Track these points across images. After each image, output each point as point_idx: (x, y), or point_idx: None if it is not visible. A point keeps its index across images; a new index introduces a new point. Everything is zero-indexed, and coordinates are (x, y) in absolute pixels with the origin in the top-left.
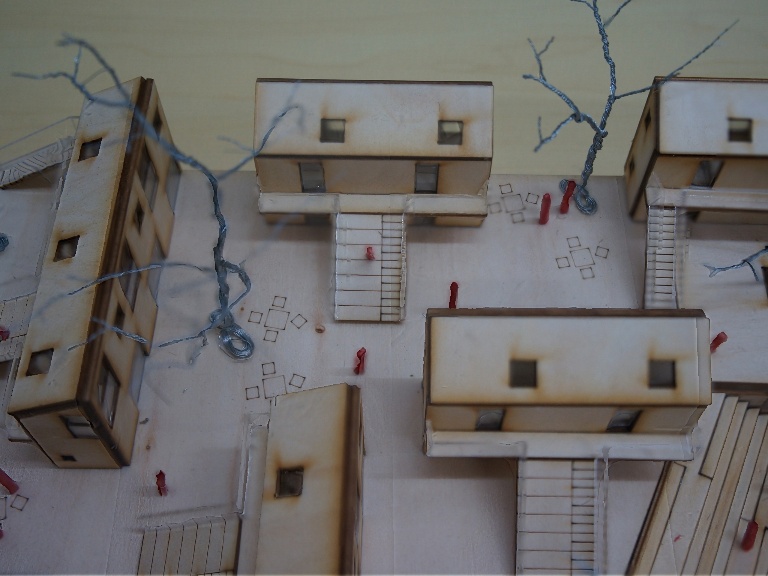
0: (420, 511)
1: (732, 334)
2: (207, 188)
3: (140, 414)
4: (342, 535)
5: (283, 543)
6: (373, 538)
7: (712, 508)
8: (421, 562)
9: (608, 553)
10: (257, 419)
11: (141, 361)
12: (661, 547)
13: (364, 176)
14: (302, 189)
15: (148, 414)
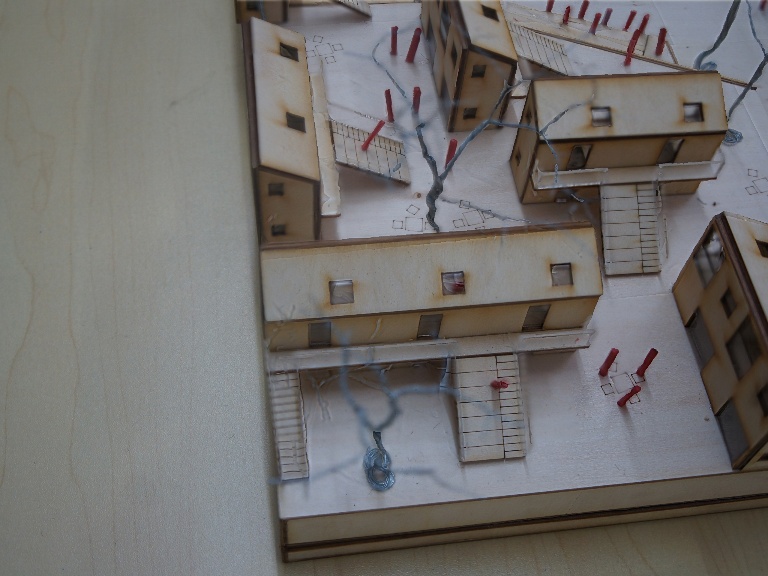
0: None
1: None
2: None
3: None
4: None
5: (640, 115)
6: None
7: None
8: None
9: None
10: (502, 225)
11: None
12: None
13: None
14: None
15: None
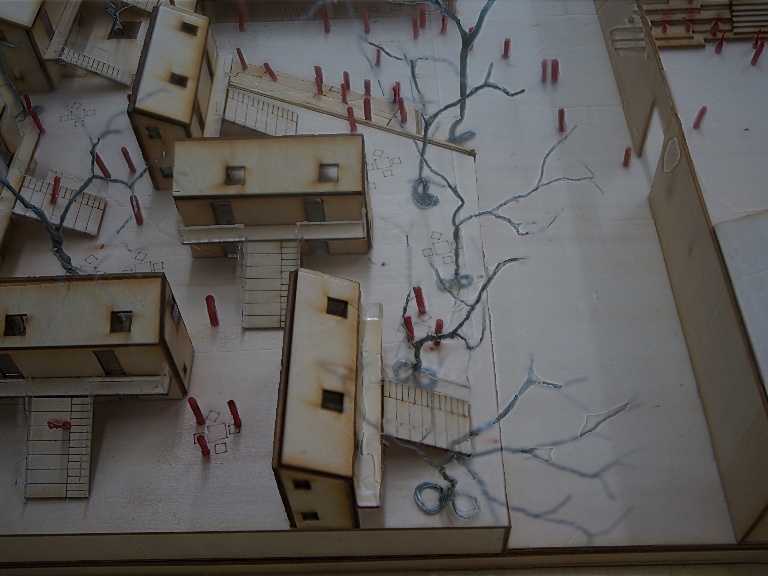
0: None
1: None
2: None
3: None
4: None
5: (274, 175)
6: None
7: None
8: None
9: None
10: (167, 276)
11: None
12: None
13: None
14: None
15: None
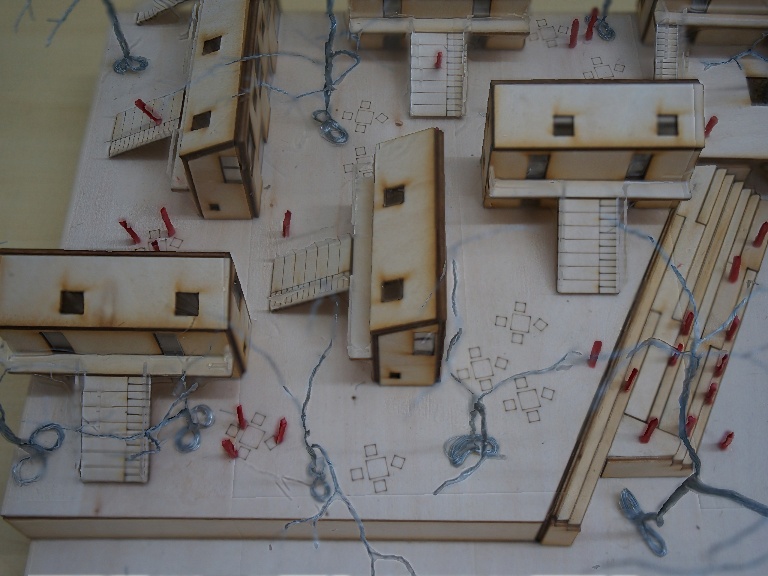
0: (483, 246)
1: (722, 124)
2: (302, 23)
3: (263, 182)
4: (437, 222)
5: (392, 233)
6: (448, 264)
7: (706, 247)
8: (485, 279)
9: (627, 273)
10: None
11: (261, 145)
12: (667, 272)
13: (433, 1)
14: (383, 15)
15: (270, 182)
